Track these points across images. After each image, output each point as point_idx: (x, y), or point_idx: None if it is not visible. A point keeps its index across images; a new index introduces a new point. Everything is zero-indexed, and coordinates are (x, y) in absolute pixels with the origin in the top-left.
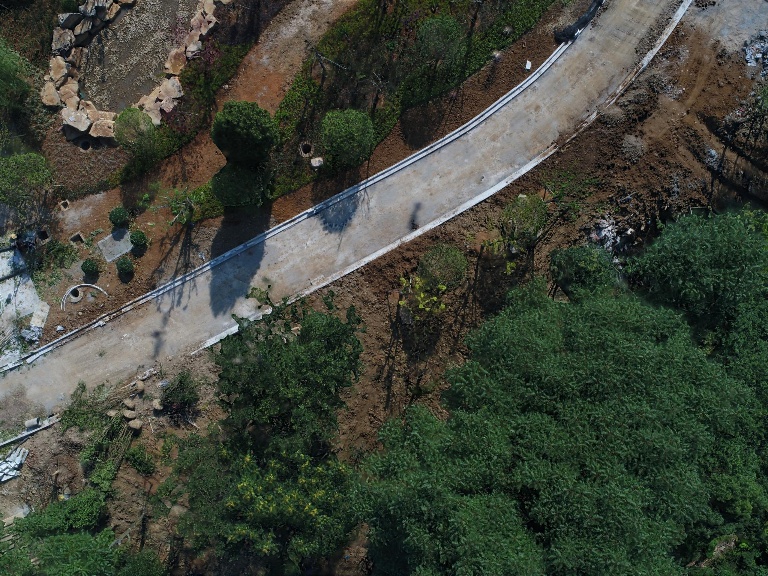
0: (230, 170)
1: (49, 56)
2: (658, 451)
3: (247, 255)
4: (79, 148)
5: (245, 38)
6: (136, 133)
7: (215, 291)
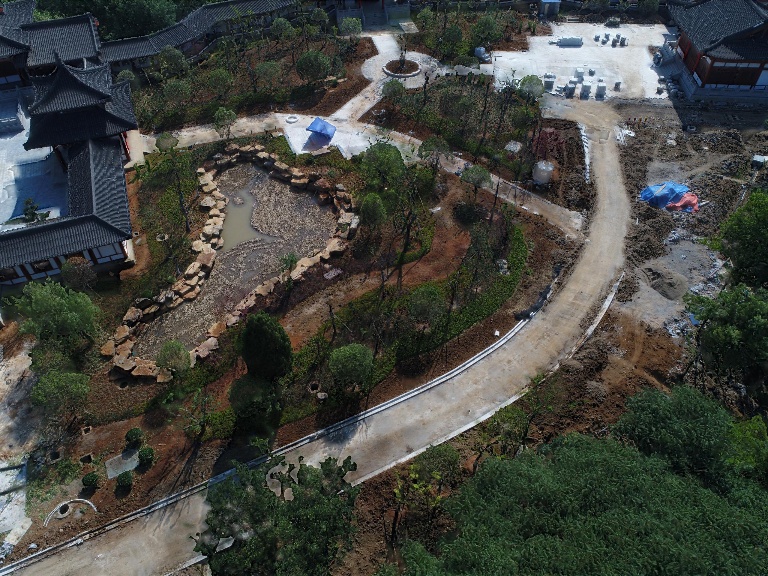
0: (249, 376)
1: (118, 326)
2: (676, 556)
3: None
4: (117, 387)
5: (275, 314)
6: (176, 356)
7: (207, 509)
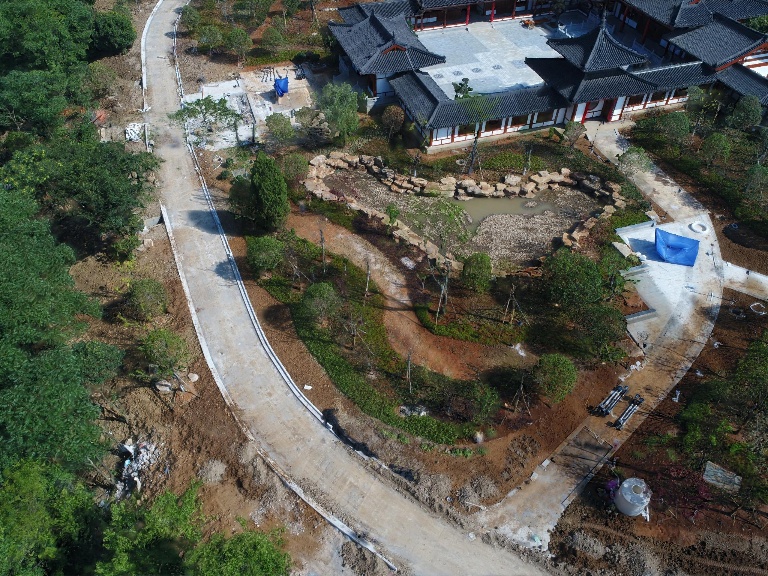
0: None
1: None
2: None
3: (213, 226)
4: None
5: (356, 227)
6: (290, 162)
7: (196, 212)
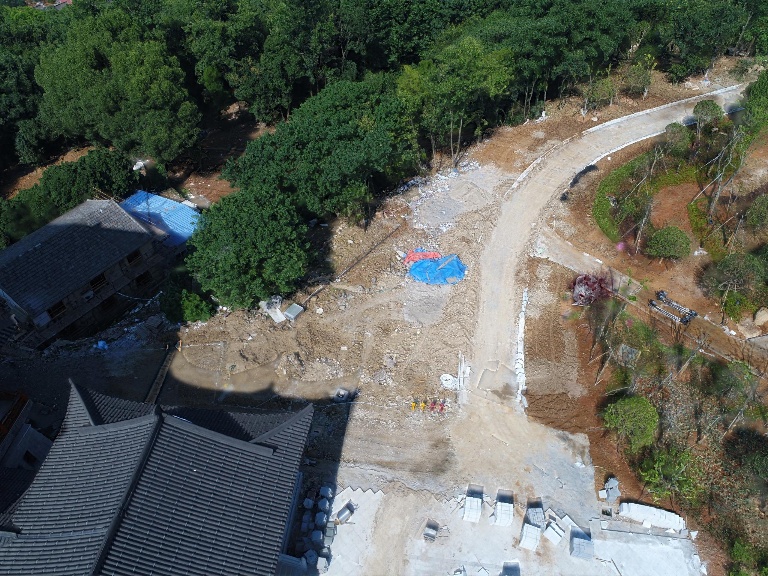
0: None
1: None
2: None
3: None
4: None
5: None
6: None
7: None
